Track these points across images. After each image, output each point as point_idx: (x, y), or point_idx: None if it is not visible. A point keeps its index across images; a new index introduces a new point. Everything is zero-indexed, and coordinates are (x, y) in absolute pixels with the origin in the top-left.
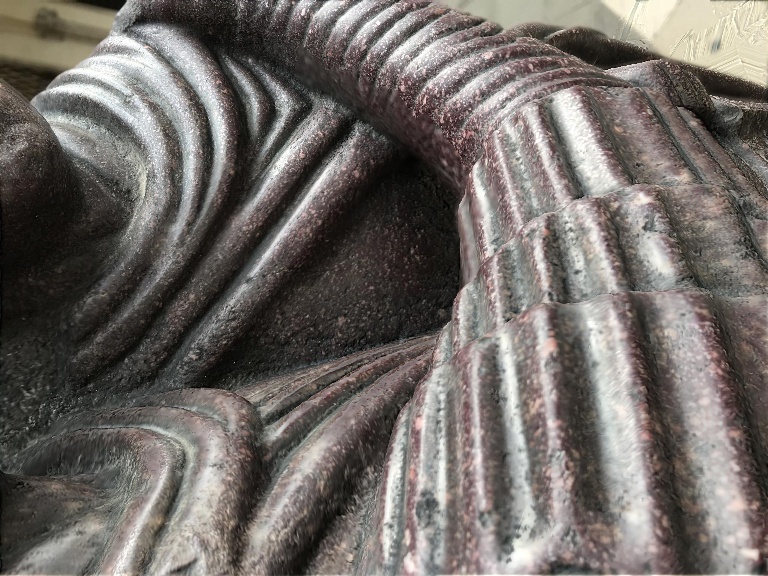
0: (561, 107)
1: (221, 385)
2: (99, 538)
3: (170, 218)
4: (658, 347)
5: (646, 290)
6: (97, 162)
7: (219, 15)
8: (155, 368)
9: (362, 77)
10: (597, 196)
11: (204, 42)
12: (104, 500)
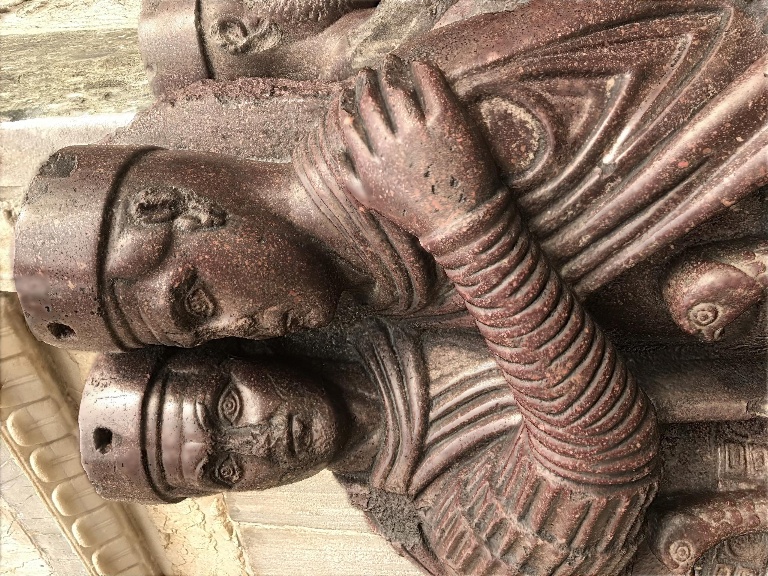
0: (544, 487)
1: None
2: (379, 448)
3: (395, 303)
4: (494, 570)
5: (510, 555)
6: (350, 261)
7: None
8: None
9: None
10: (519, 530)
11: None
12: (380, 424)
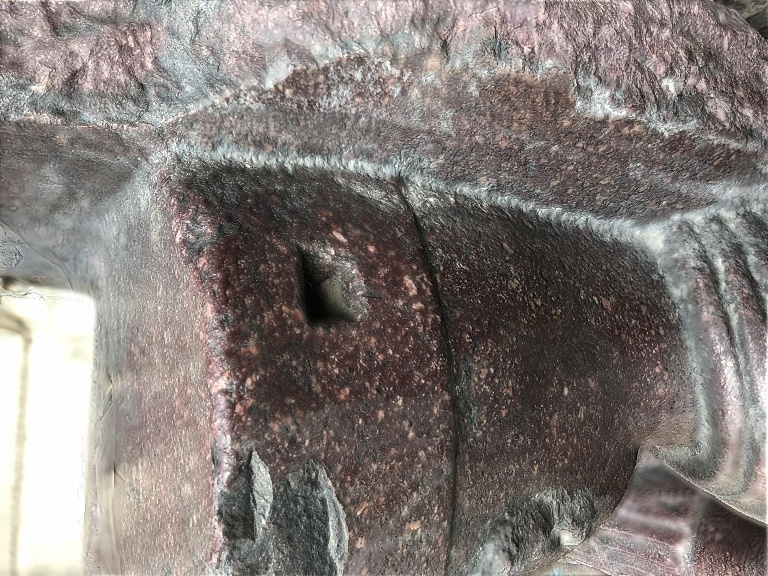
0: None
1: None
2: None
3: None
4: None
5: None
6: None
7: None
8: None
9: (762, 566)
10: None
11: None
12: None
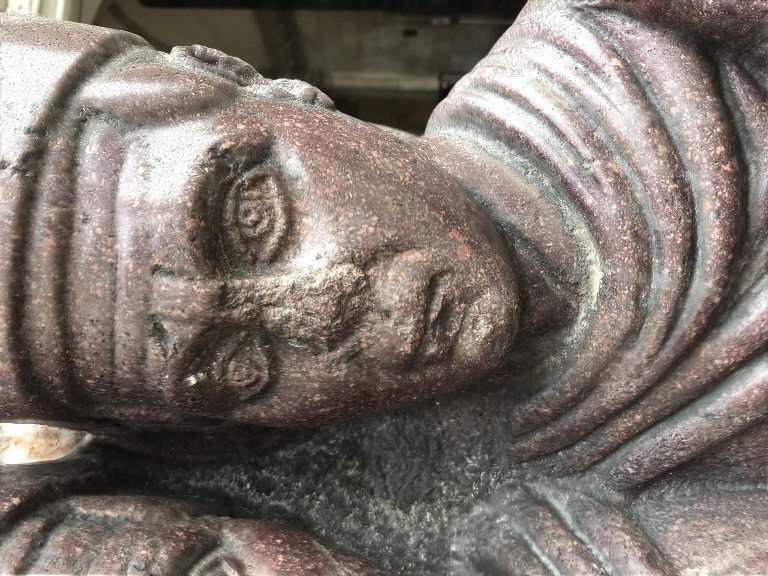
0: None
1: (653, 490)
2: None
3: (627, 344)
4: None
5: None
6: (542, 245)
7: (742, 24)
8: (588, 465)
9: None
10: None
11: (702, 48)
12: None
